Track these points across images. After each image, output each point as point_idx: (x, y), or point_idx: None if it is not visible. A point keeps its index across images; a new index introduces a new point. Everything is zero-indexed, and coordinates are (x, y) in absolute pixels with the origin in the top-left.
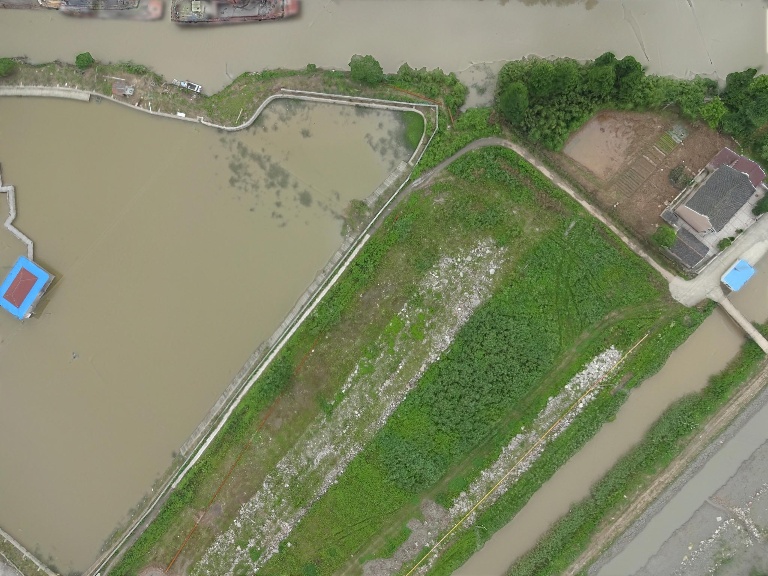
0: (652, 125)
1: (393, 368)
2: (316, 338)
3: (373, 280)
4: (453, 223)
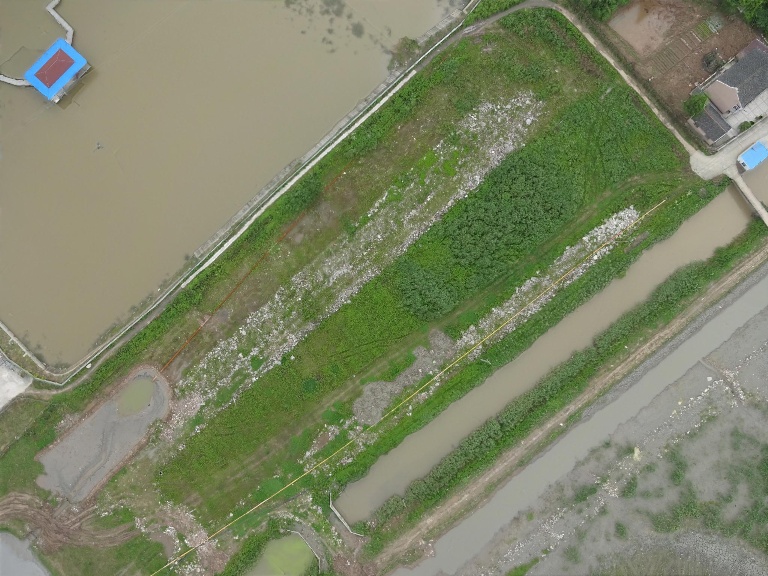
0: (692, 13)
1: (421, 199)
2: (349, 161)
3: (413, 114)
4: (498, 72)
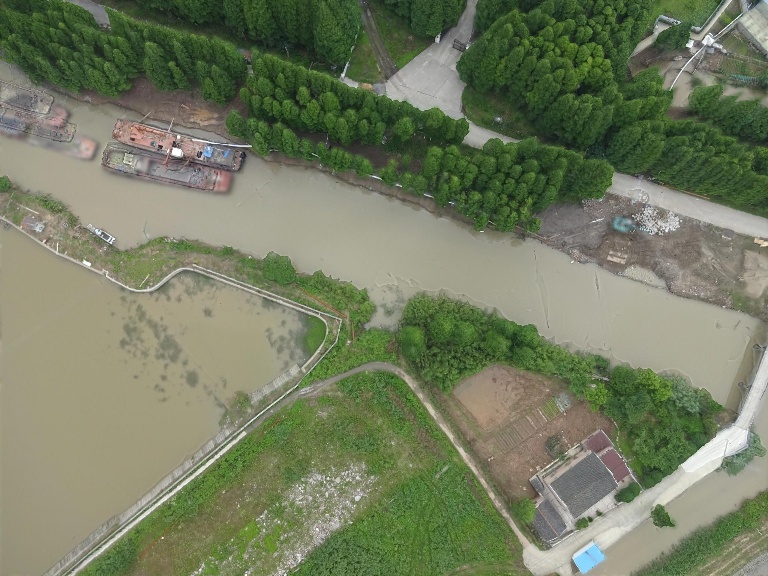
0: (541, 387)
1: (238, 575)
2: (168, 526)
3: (239, 479)
4: (331, 440)
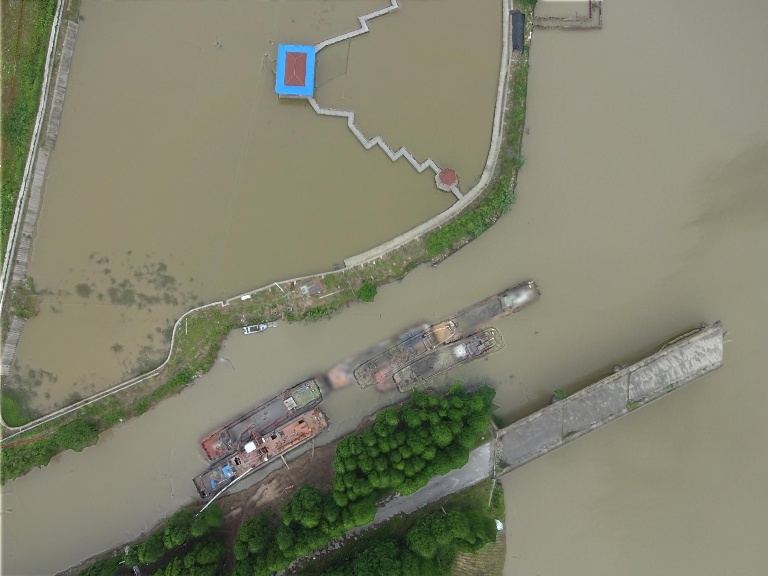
0: None
1: None
2: (2, 178)
3: None
4: None
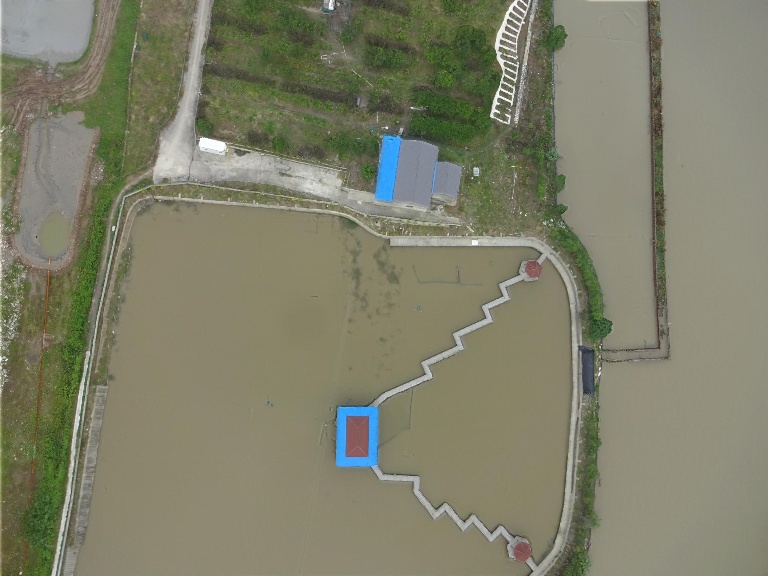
0: None
1: None
2: None
3: None
4: None
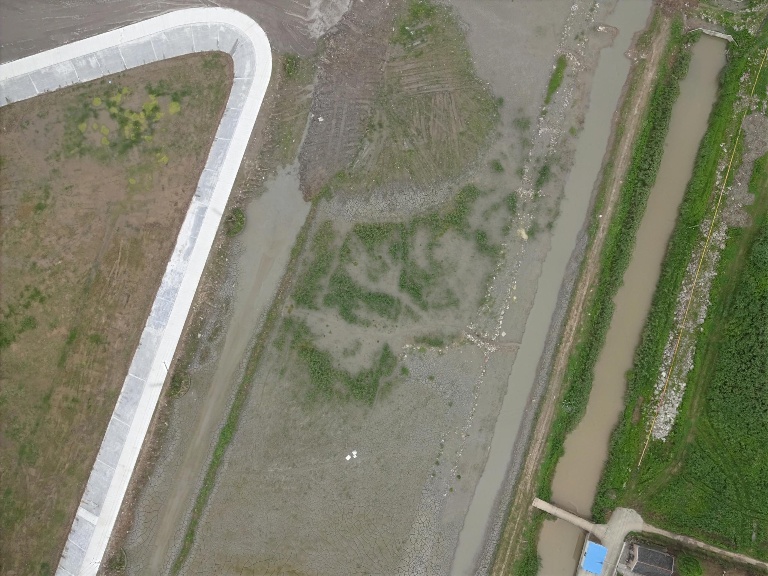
0: None
1: None
2: None
3: None
4: None
